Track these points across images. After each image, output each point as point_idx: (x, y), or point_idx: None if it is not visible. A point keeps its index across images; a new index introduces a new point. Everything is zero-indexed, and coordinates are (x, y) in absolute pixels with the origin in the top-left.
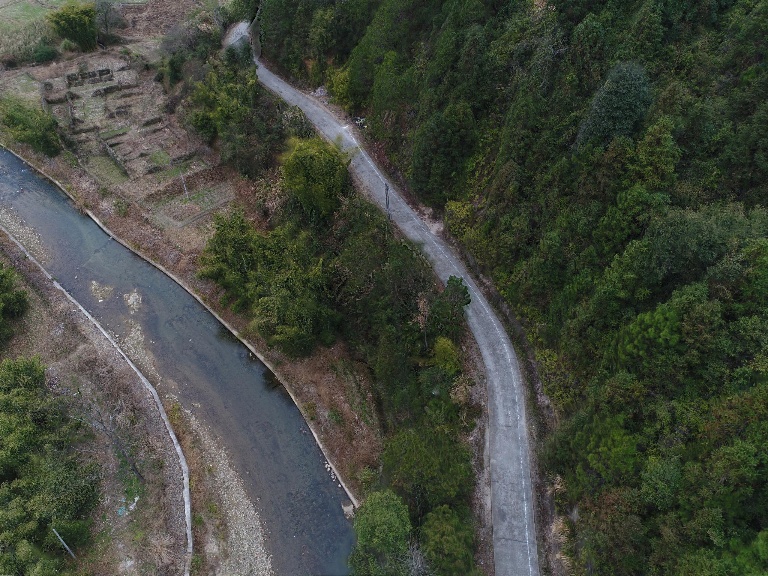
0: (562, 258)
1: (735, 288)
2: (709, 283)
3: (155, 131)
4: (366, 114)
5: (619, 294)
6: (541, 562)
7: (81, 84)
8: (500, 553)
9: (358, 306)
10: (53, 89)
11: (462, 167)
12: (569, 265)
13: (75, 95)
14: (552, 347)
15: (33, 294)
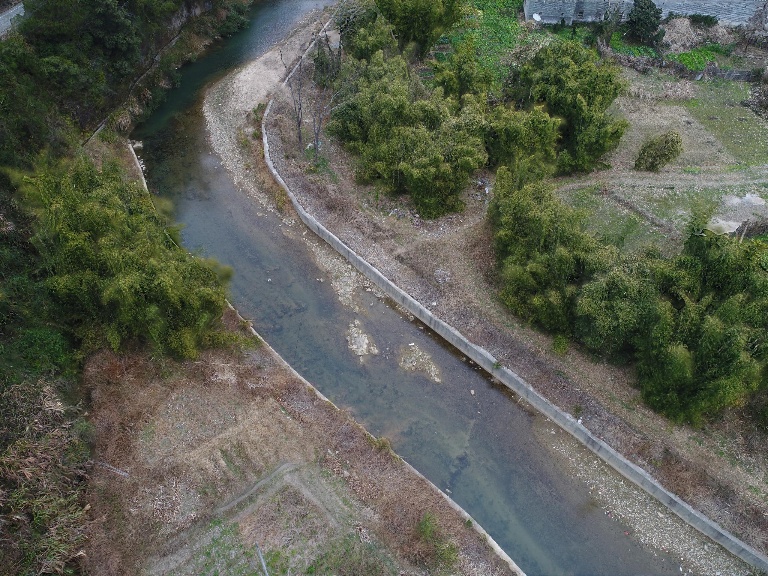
0: None
1: None
2: None
3: None
4: None
5: None
6: None
7: None
8: None
9: None
10: None
11: None
12: None
13: None
14: None
15: (513, 334)
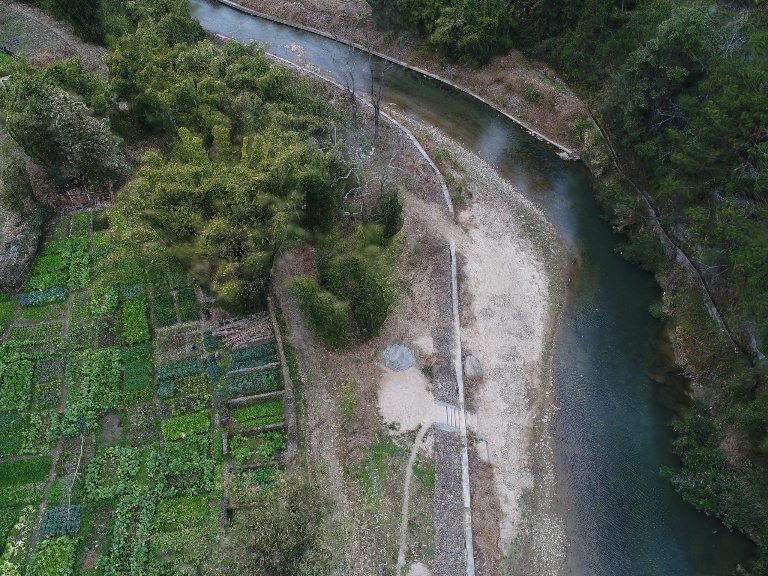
0: None
1: None
2: None
3: None
4: None
5: None
6: None
7: None
8: None
9: (531, 15)
10: None
11: None
12: None
13: None
14: None
15: None
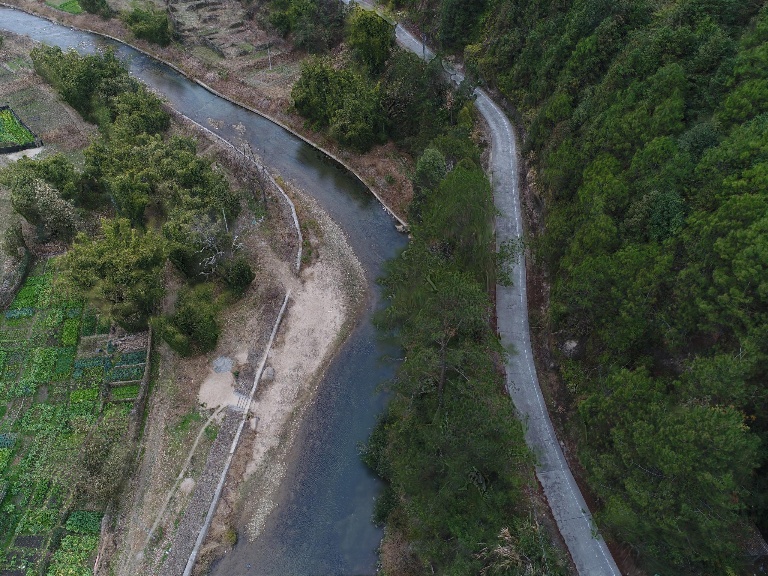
0: (539, 49)
1: (626, 16)
2: (612, 14)
3: (239, 31)
4: (404, 9)
5: (568, 43)
6: (521, 200)
7: (176, 2)
8: (497, 197)
9: None
10: (155, 5)
11: (476, 20)
12: (544, 52)
13: (174, 8)
14: (533, 106)
15: None
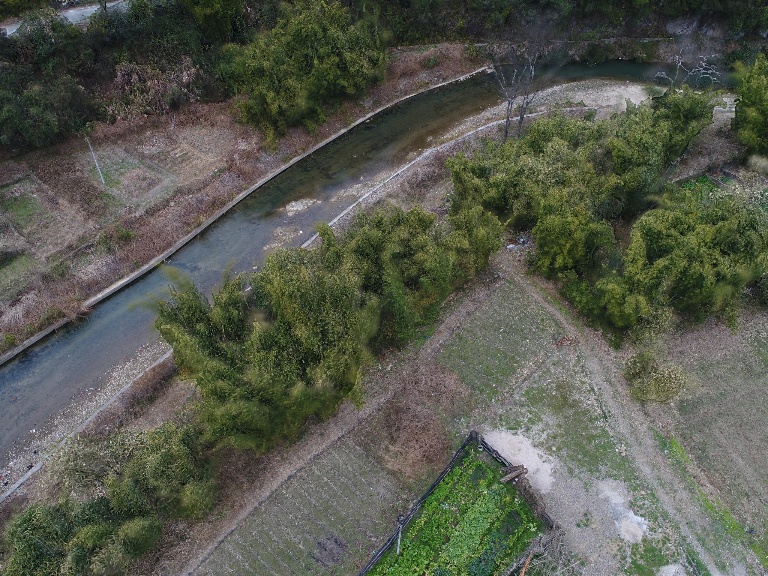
0: None
1: None
2: None
3: None
4: None
5: None
6: None
7: None
8: None
9: None
10: None
11: None
12: None
13: None
14: None
15: None
